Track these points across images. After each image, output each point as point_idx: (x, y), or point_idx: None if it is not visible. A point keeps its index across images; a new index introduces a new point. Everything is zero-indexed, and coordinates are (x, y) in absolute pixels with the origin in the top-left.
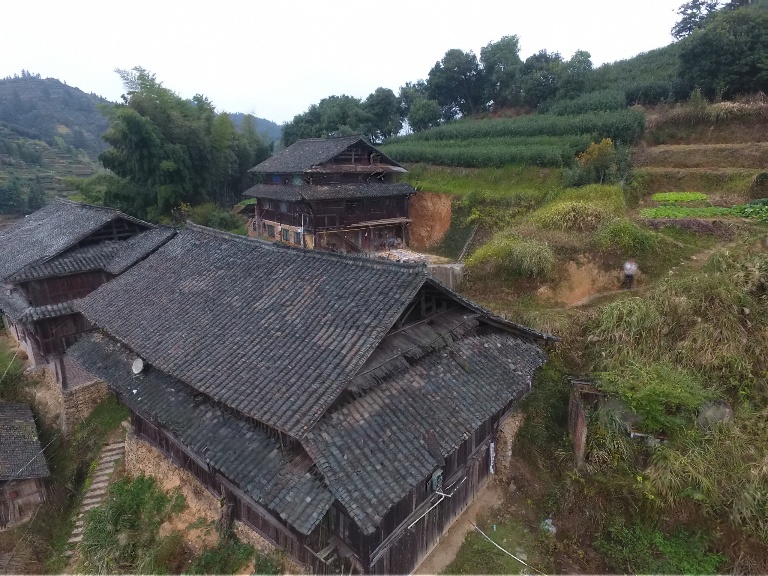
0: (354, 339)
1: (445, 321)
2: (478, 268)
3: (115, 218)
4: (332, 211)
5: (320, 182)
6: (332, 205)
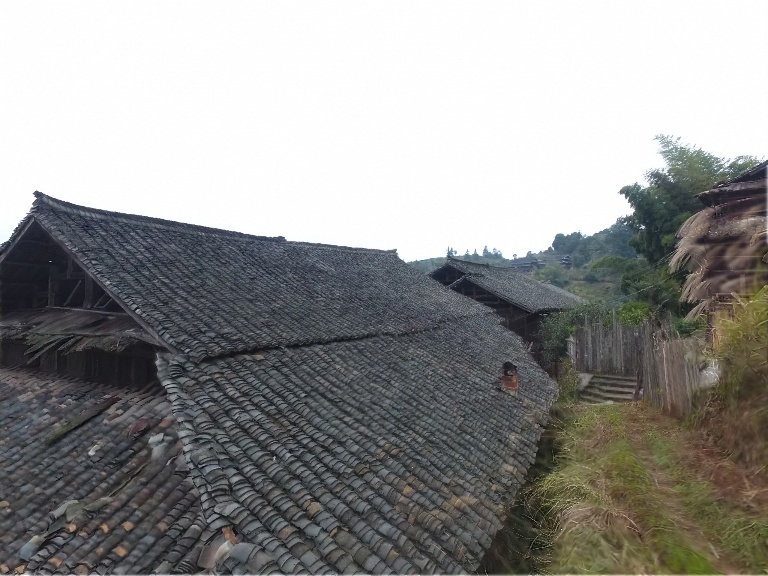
0: None
1: (114, 324)
2: (736, 348)
3: (446, 266)
4: (760, 263)
5: (741, 211)
6: (760, 251)
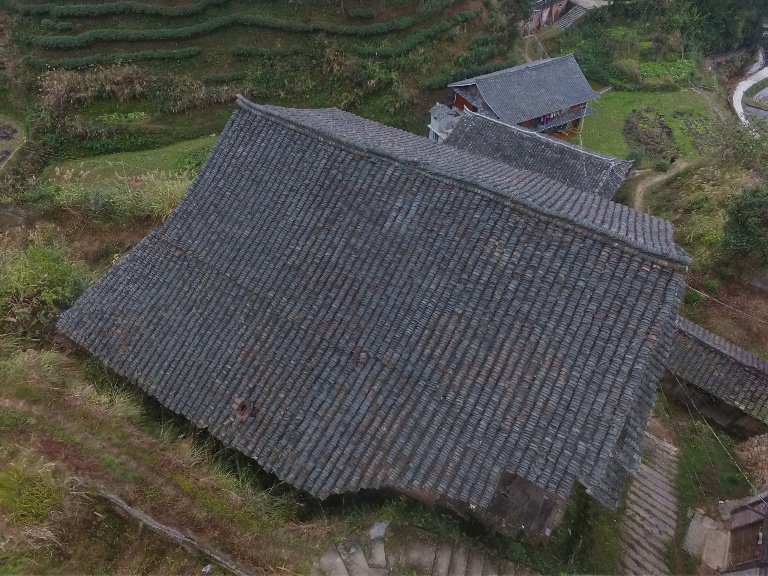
0: (304, 112)
1: None
2: None
3: None
4: None
5: None
6: None
